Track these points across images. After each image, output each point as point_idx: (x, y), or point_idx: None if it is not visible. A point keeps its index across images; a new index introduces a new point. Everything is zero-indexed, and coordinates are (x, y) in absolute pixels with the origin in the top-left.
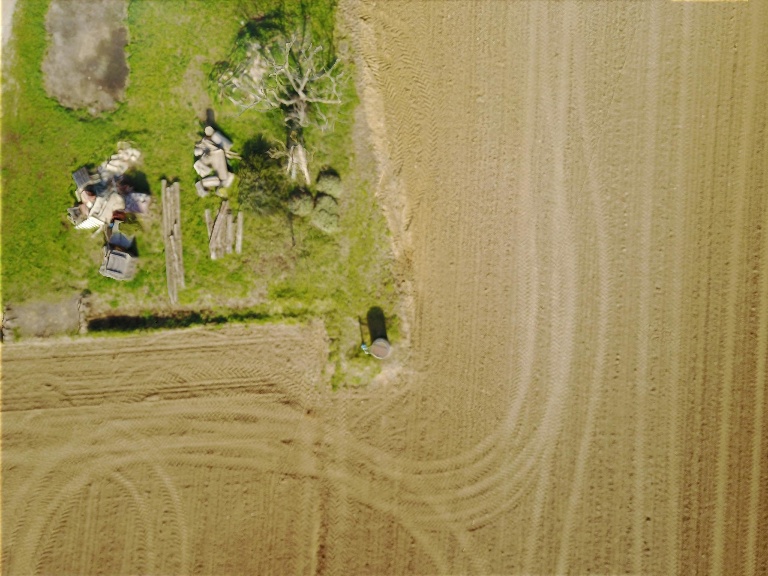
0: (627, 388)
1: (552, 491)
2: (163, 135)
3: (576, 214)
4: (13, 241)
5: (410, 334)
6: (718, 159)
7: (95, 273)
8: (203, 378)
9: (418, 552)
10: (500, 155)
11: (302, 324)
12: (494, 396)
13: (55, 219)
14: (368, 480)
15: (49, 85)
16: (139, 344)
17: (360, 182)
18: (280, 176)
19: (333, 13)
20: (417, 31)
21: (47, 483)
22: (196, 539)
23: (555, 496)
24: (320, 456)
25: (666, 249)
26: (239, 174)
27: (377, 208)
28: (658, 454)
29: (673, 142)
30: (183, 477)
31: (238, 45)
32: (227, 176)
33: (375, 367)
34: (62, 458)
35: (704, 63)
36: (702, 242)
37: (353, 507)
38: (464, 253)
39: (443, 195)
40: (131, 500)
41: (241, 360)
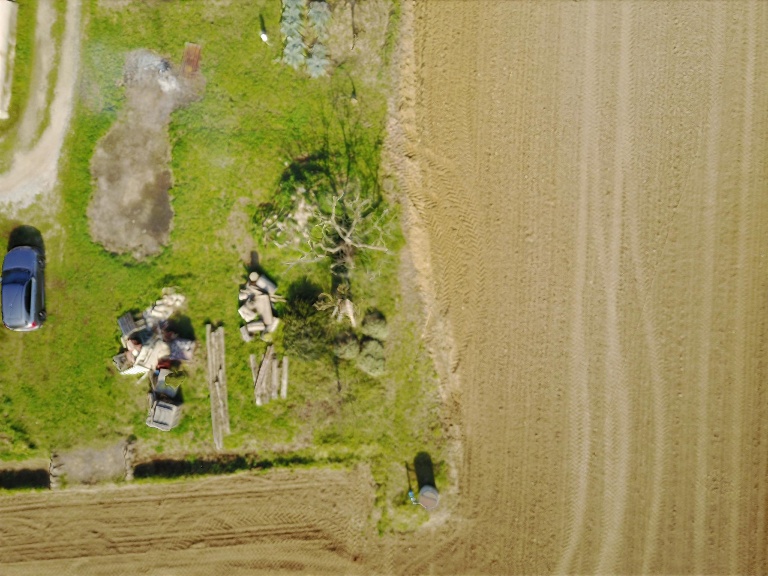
0: (685, 541)
1: None
2: (207, 278)
3: (629, 358)
4: (60, 387)
5: (458, 480)
6: None
7: (141, 419)
8: (249, 524)
9: None
10: (550, 296)
11: (348, 469)
12: (546, 546)
13: (101, 364)
14: None
15: (94, 229)
16: (185, 490)
17: (406, 324)
18: (325, 321)
19: (378, 152)
20: (463, 169)
21: None
22: None
23: None
24: None
25: (725, 397)
26: (284, 319)
27: (424, 350)
28: None
29: (731, 283)
30: None
31: (282, 188)
32: (272, 321)
33: (423, 515)
34: None
35: (763, 200)
36: (762, 387)
37: None
38: (513, 397)
39: (491, 337)
40: None
41: (287, 505)
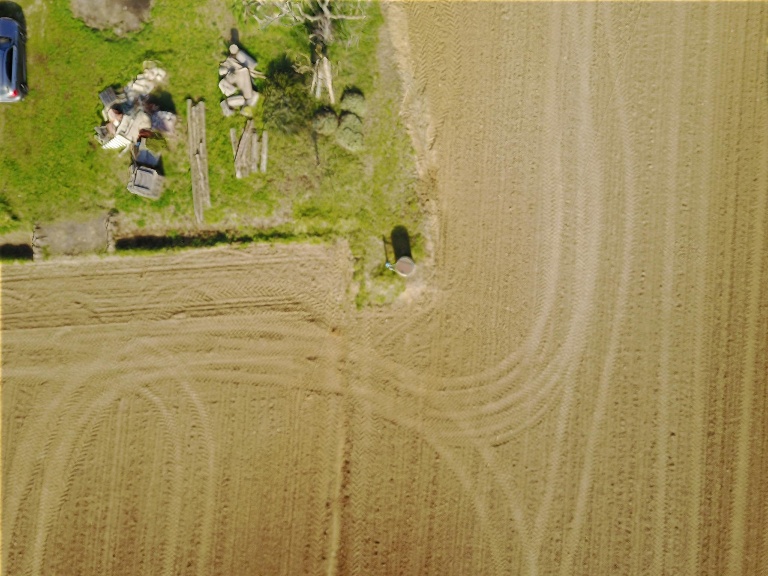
0: (652, 304)
1: (576, 407)
2: (188, 55)
3: (602, 131)
4: (42, 161)
5: (434, 253)
6: (747, 74)
7: (122, 192)
8: (229, 296)
9: (442, 467)
10: (525, 72)
11: (327, 243)
12: (518, 313)
13: (82, 139)
14: (393, 397)
15: (75, 5)
16: (166, 263)
17: (384, 101)
18: (304, 94)
19: None
20: None
21: (78, 398)
22: (223, 453)
23: (579, 412)
24: (345, 373)
25: (693, 164)
26: (264, 93)
27: (401, 127)
28: (683, 370)
29: (701, 57)
30: (210, 393)
31: None
32: (252, 95)
33: (399, 285)
34: (92, 374)
35: None
36: (730, 158)
37: (378, 423)
38: (488, 171)
39: (467, 113)
40: (160, 415)
41: (266, 279)
